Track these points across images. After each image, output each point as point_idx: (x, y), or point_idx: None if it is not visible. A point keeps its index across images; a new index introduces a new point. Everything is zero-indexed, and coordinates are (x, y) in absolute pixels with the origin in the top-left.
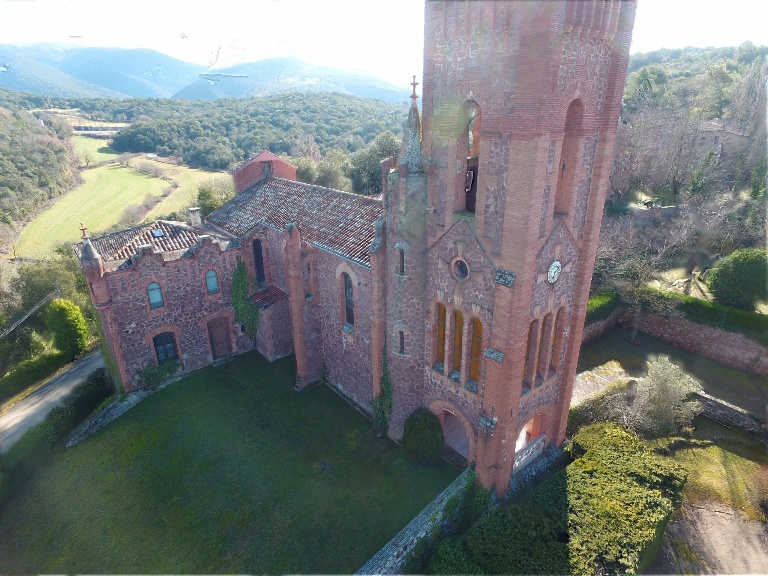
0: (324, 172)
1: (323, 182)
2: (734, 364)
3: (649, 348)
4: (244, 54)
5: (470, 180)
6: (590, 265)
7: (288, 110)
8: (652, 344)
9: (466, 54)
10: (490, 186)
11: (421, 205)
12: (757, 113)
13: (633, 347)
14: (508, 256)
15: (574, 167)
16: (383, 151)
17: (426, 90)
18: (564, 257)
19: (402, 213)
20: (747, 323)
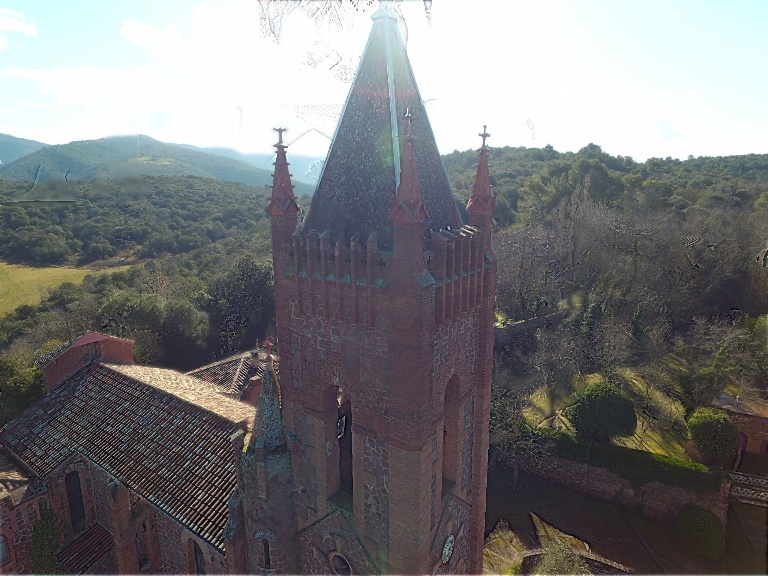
0: (174, 312)
1: (173, 323)
2: (604, 497)
3: (530, 493)
4: (71, 178)
5: (342, 426)
6: (482, 516)
7: (131, 226)
8: (532, 486)
9: (327, 337)
10: (369, 485)
11: (286, 486)
12: (574, 235)
13: (516, 495)
14: (398, 569)
15: (456, 435)
16: (243, 275)
17: (283, 357)
18: (456, 524)
19: (263, 498)
20: (608, 457)
